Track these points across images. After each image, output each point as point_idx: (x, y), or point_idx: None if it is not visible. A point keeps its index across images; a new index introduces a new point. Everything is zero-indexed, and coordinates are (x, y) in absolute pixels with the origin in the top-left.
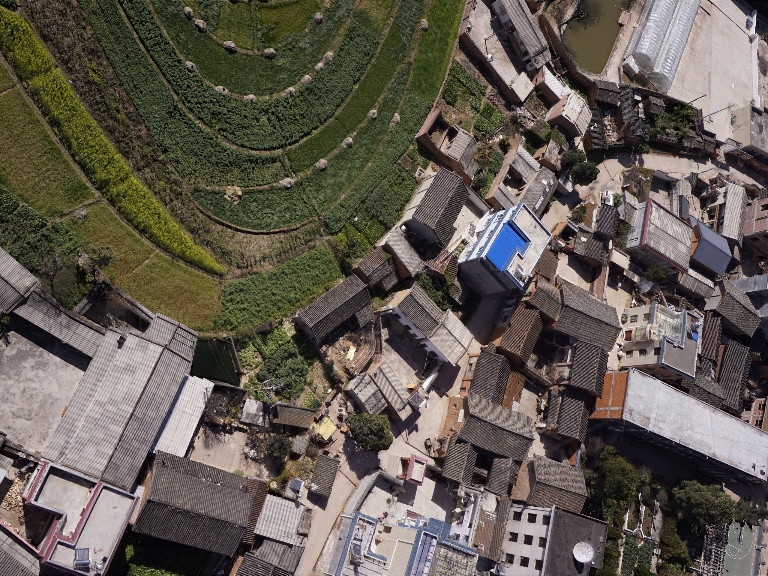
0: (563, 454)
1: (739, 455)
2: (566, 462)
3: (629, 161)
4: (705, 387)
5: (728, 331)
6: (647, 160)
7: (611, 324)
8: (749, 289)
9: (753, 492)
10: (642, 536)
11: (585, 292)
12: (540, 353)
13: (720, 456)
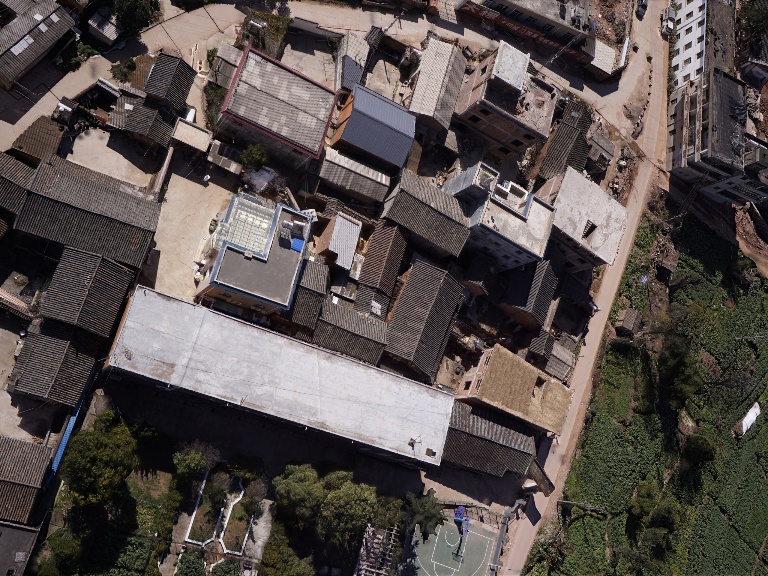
0: (50, 424)
1: (380, 425)
2: (46, 436)
3: (259, 9)
4: (348, 326)
5: (433, 251)
6: (297, 10)
7: (132, 224)
8: (458, 188)
9: (491, 486)
10: (223, 550)
11: (112, 181)
12: (35, 273)
13: (336, 426)
